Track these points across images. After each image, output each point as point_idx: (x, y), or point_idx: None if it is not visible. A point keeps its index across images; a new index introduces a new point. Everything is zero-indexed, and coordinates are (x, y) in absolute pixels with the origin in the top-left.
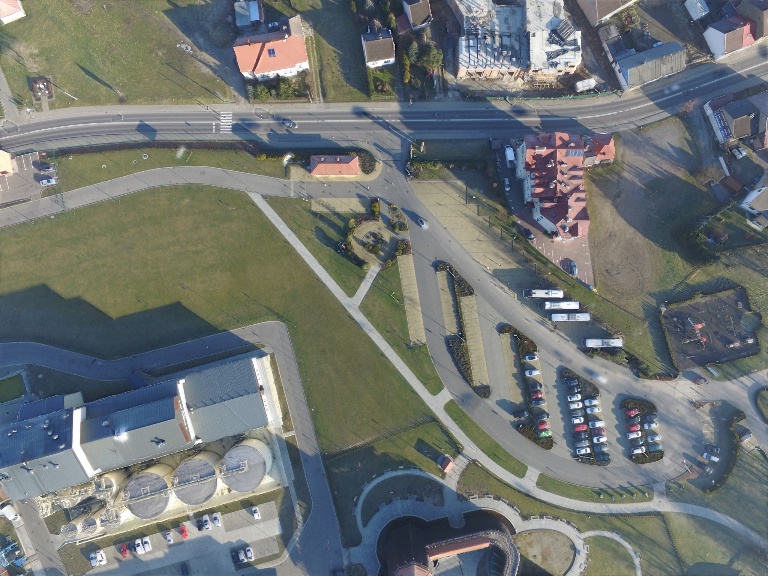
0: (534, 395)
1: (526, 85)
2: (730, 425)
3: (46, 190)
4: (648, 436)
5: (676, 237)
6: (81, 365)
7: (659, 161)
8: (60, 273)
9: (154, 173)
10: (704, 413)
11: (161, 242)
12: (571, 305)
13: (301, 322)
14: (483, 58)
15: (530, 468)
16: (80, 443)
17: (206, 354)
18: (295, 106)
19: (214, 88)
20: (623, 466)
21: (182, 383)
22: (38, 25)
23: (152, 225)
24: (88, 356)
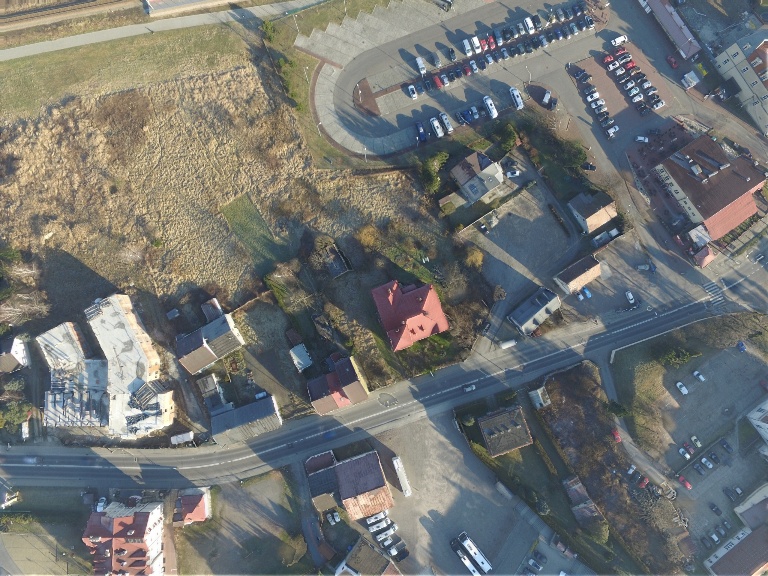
0: None
1: None
2: None
3: None
4: None
5: None
6: None
7: (258, 518)
8: None
9: None
10: None
11: None
12: None
13: None
14: (69, 414)
15: None
16: None
17: None
18: None
19: None
20: None
21: None
22: None
23: None
24: None
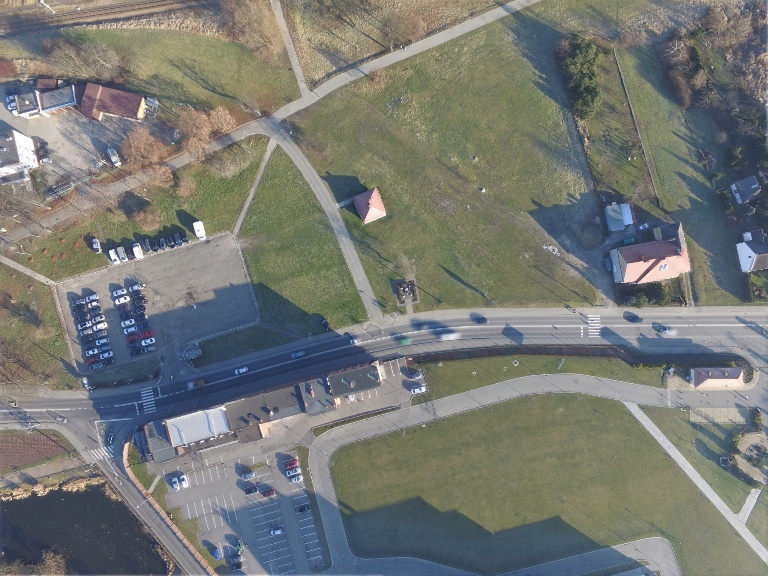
0: None
1: None
2: None
3: (416, 398)
4: None
5: None
6: None
7: None
8: (435, 485)
9: (526, 380)
10: None
11: (537, 453)
12: None
13: (686, 539)
14: None
15: None
16: None
17: (588, 570)
18: (665, 310)
19: (584, 292)
20: None
21: None
22: (400, 225)
23: (527, 435)
24: (468, 572)
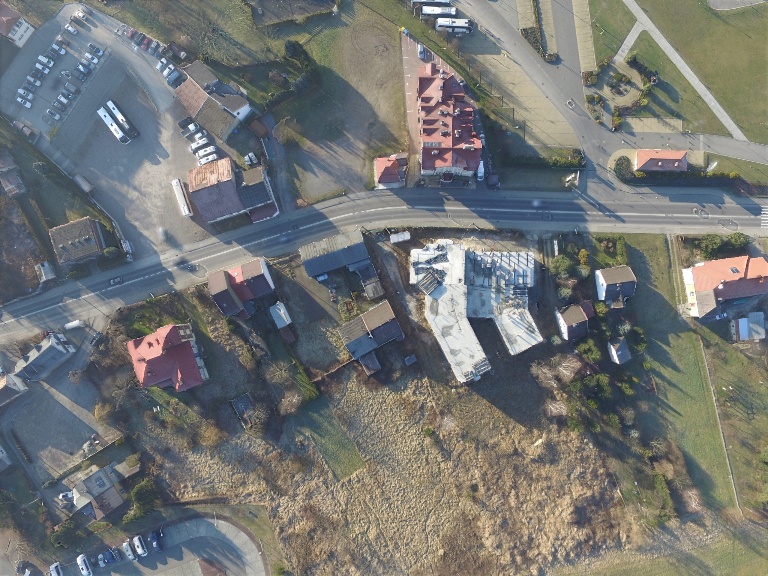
0: None
1: None
2: None
3: None
4: None
5: None
6: None
7: (328, 158)
8: None
9: None
10: None
11: None
12: (430, 10)
13: (694, 8)
14: None
15: None
16: None
17: None
18: (696, 231)
19: None
20: None
21: None
22: None
23: None
24: None
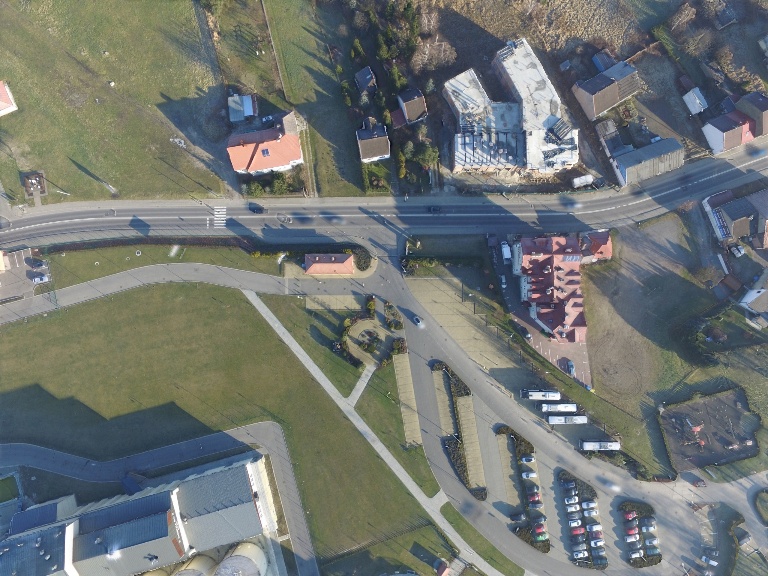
0: (531, 498)
1: (523, 180)
2: (729, 529)
3: (39, 287)
4: (646, 539)
5: (674, 337)
6: (74, 466)
7: (657, 258)
8: (53, 373)
9: (147, 270)
10: (703, 515)
11: (155, 341)
12: (568, 408)
13: (296, 423)
14: (479, 155)
15: (527, 572)
16: (72, 562)
17: (200, 455)
18: (289, 201)
19: (208, 183)
20: (621, 569)
21: (176, 493)
22: (30, 119)
23: (146, 323)
24: (81, 457)
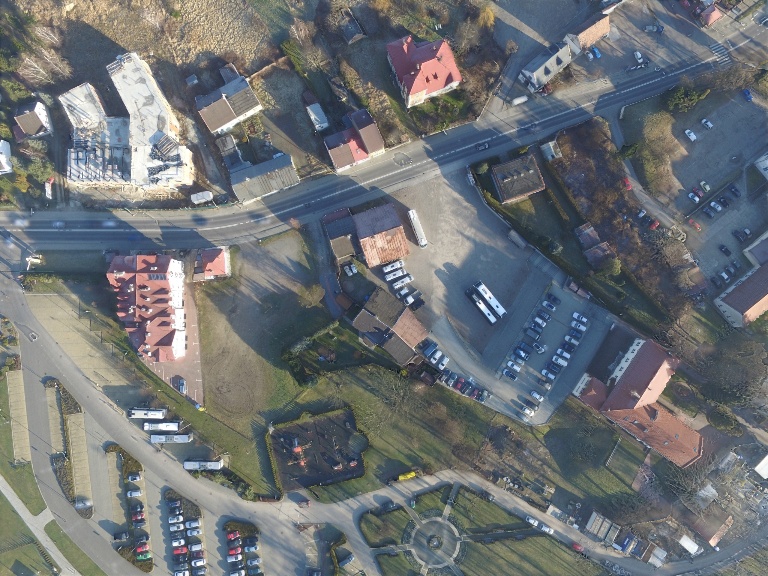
0: (133, 517)
1: (148, 195)
2: (328, 550)
3: None
4: (248, 559)
5: None
6: None
7: (276, 275)
8: None
9: None
10: (308, 536)
11: None
12: (170, 426)
13: None
14: (92, 171)
15: None
16: None
17: None
18: None
19: None
20: None
21: None
22: None
23: None
24: None
